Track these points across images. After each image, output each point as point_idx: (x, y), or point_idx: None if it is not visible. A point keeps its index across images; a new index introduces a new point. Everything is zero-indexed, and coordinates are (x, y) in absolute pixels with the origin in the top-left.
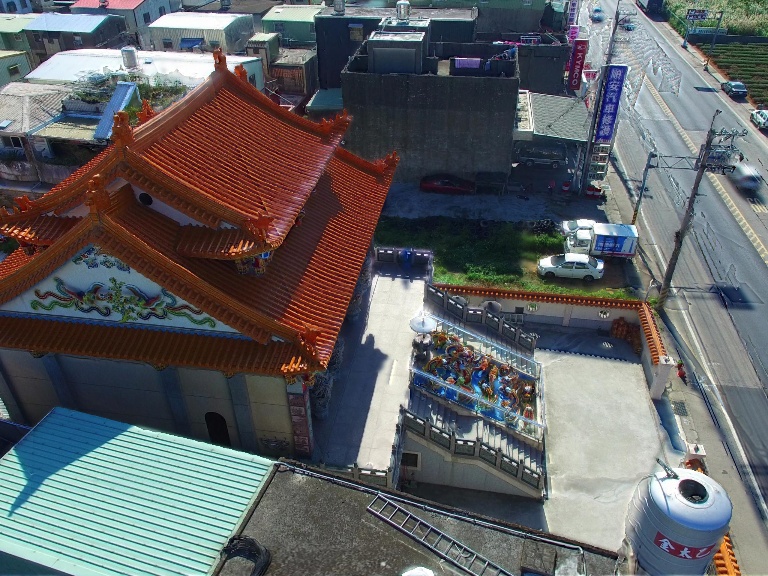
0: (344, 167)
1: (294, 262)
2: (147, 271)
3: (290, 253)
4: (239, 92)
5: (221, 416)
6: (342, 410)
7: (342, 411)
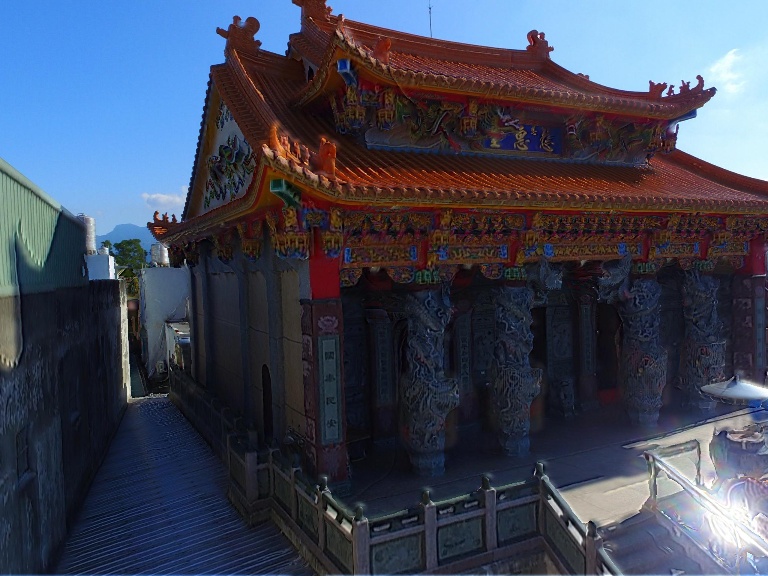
0: (698, 180)
1: (450, 165)
2: (230, 98)
3: (458, 162)
4: (552, 78)
5: (269, 373)
6: (468, 482)
7: (466, 483)
